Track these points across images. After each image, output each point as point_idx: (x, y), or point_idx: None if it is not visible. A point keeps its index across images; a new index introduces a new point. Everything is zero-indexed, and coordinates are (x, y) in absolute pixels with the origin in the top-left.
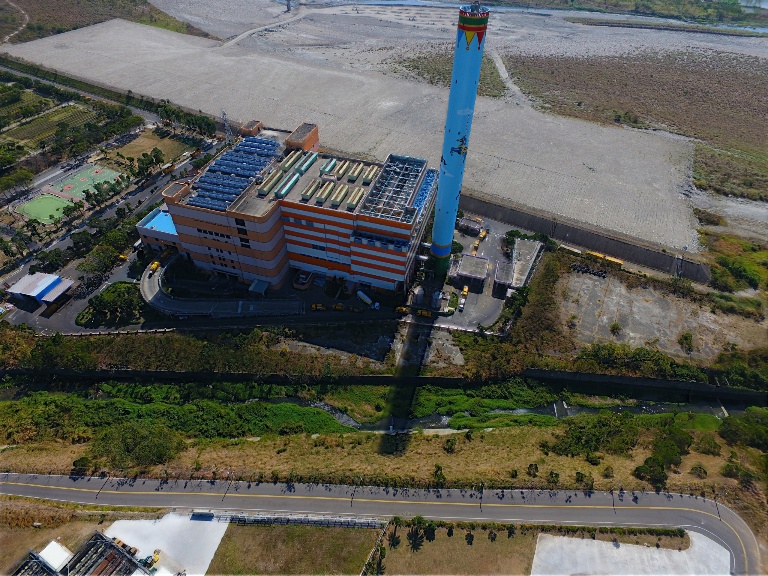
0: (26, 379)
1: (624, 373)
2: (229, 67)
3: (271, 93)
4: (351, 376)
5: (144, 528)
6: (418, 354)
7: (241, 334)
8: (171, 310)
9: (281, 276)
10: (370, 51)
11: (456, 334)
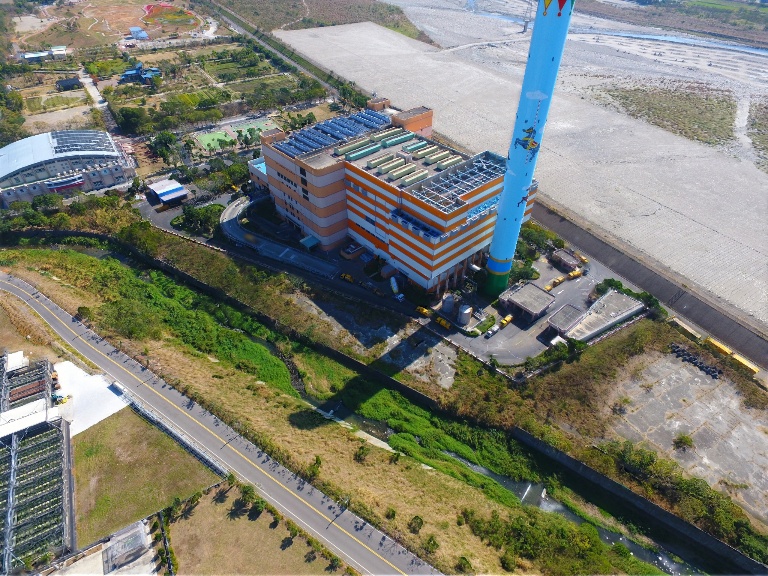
0: (115, 248)
1: (653, 498)
2: (430, 69)
3: (451, 95)
4: (327, 347)
5: (77, 375)
6: (408, 358)
7: (263, 271)
8: (231, 235)
9: (334, 240)
10: (583, 76)
11: (463, 356)
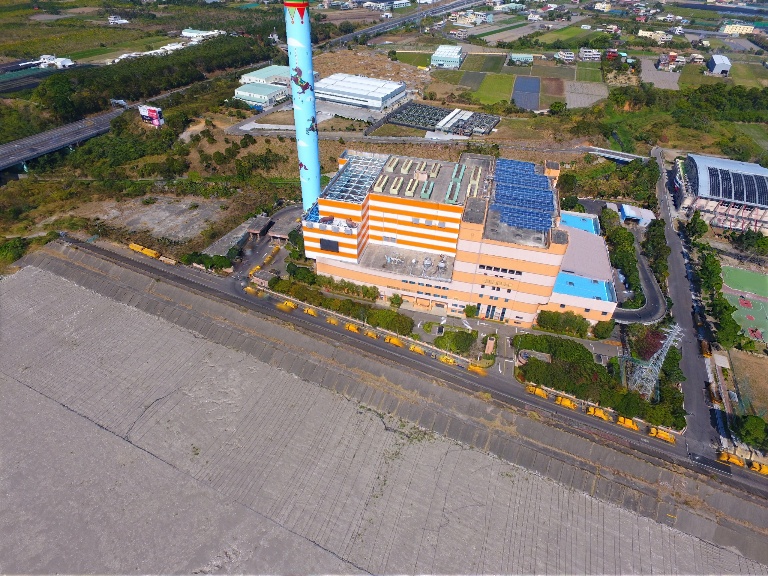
0: None
1: None
2: None
3: None
4: None
5: None
6: None
7: None
8: None
9: None
10: None
11: None
